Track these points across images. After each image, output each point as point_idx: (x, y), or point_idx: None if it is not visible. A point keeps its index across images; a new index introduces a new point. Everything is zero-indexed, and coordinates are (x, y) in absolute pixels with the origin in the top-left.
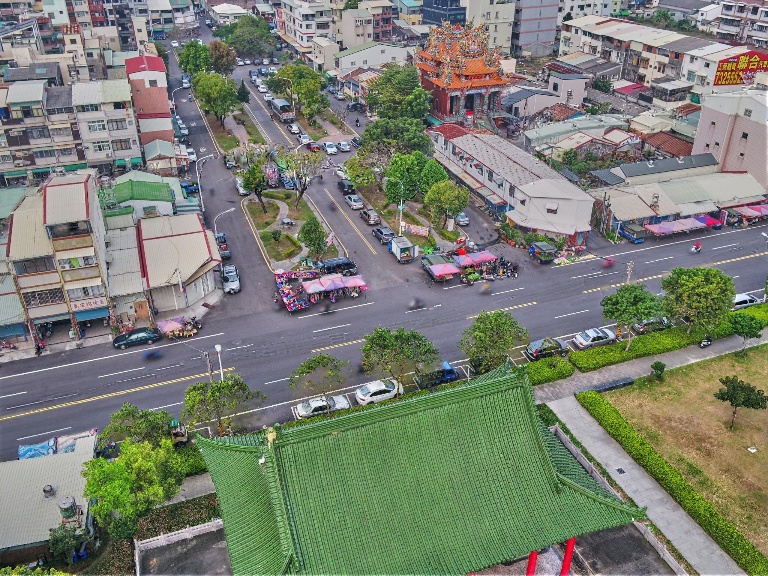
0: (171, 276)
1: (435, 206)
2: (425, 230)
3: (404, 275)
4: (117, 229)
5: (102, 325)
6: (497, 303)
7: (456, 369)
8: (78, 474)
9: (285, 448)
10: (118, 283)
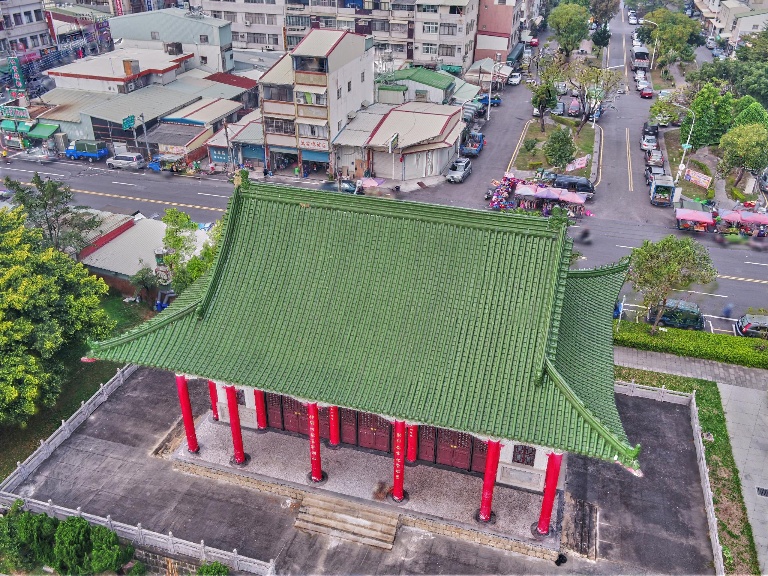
0: (390, 139)
1: (728, 151)
2: (707, 180)
3: (647, 216)
4: (386, 104)
5: (326, 173)
6: (701, 236)
7: (628, 311)
8: (199, 247)
9: (249, 201)
10: (347, 135)
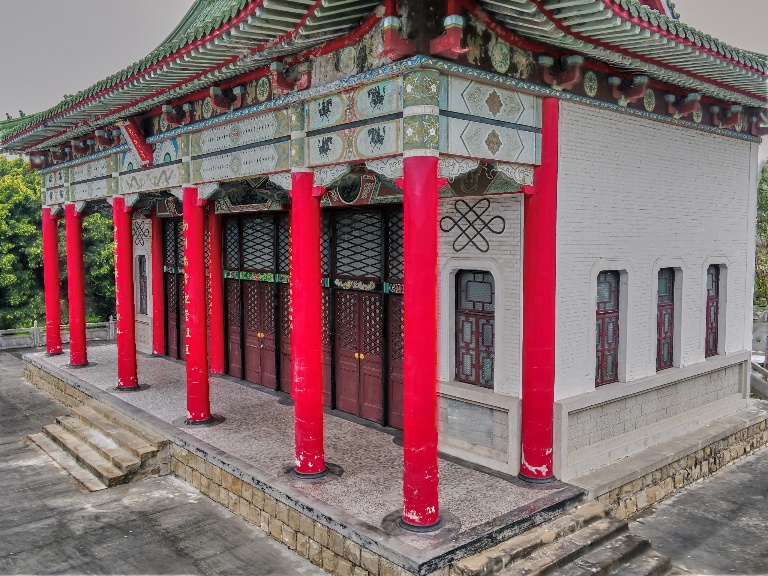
0: None
1: None
2: None
3: None
4: None
5: None
6: None
7: None
8: None
9: (210, 6)
10: None
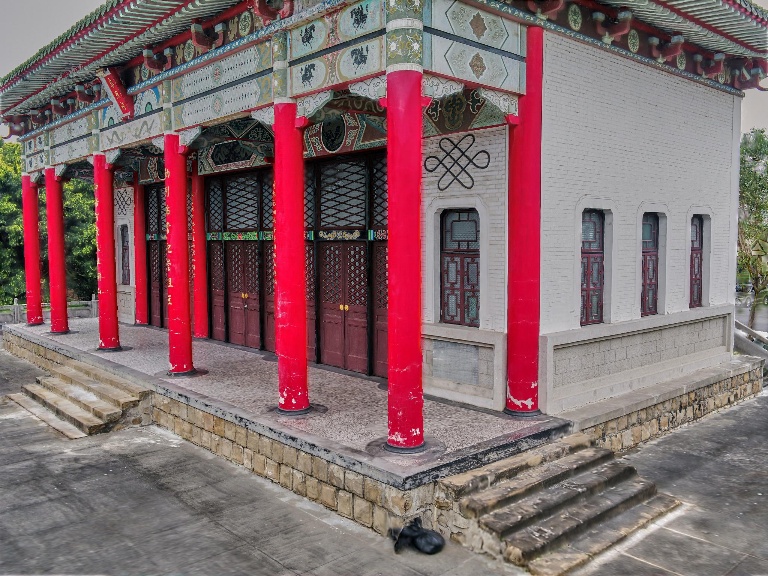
0: None
1: None
2: None
3: None
4: None
5: None
6: None
7: None
8: None
9: None
10: None
